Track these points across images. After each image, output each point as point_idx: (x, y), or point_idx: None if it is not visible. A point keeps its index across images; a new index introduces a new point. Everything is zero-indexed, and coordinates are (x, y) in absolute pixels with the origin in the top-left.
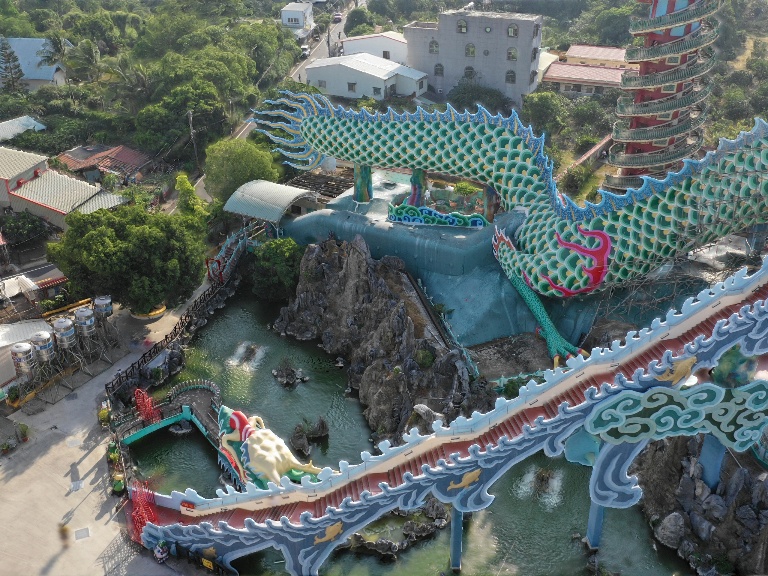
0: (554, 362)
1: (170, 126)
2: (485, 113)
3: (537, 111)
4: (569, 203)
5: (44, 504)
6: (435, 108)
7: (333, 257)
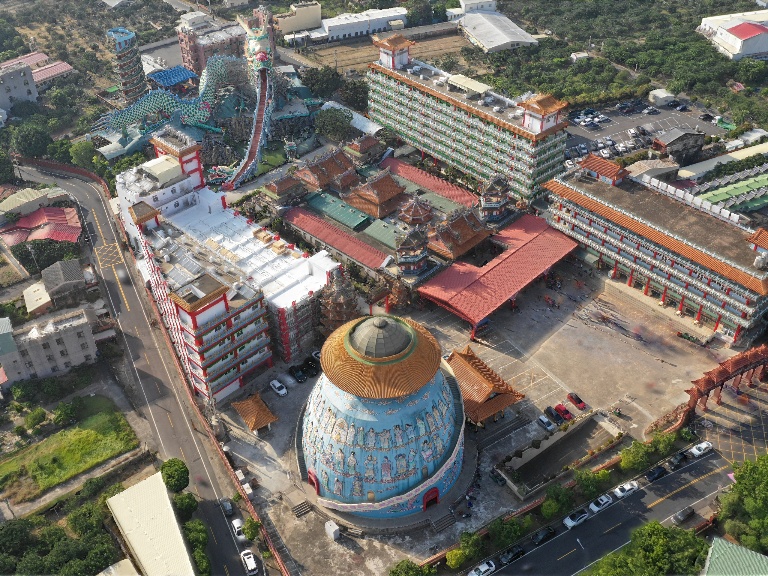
0: None
1: (2, 168)
2: None
3: None
4: None
5: None
6: (37, 116)
7: None
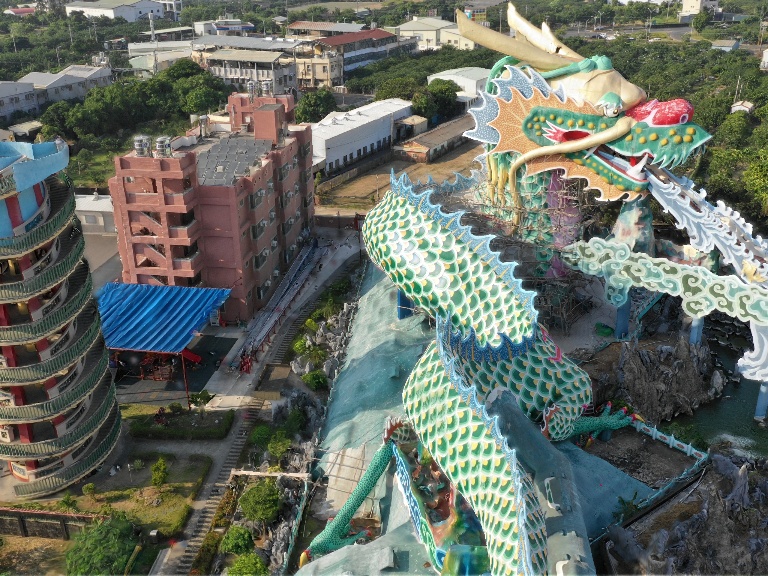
0: (640, 419)
1: None
2: None
3: None
4: None
5: None
6: None
7: None
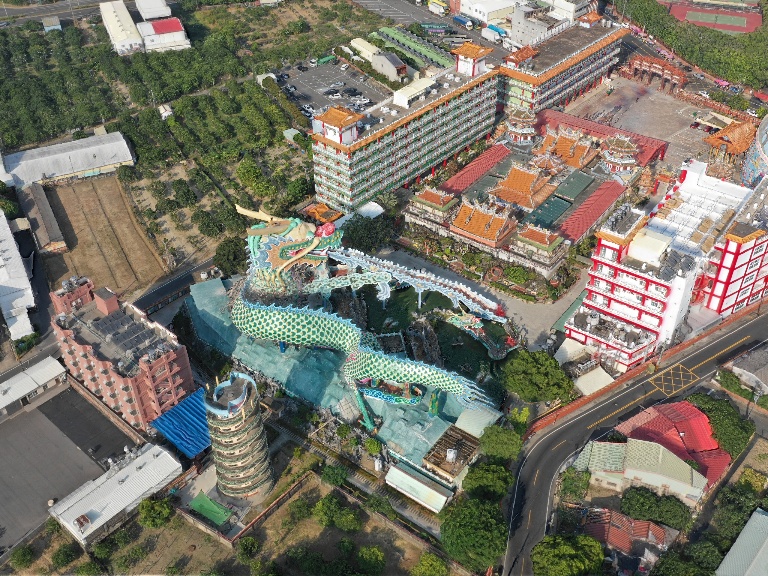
0: None
1: None
2: None
3: None
4: None
5: (530, 322)
6: None
7: None
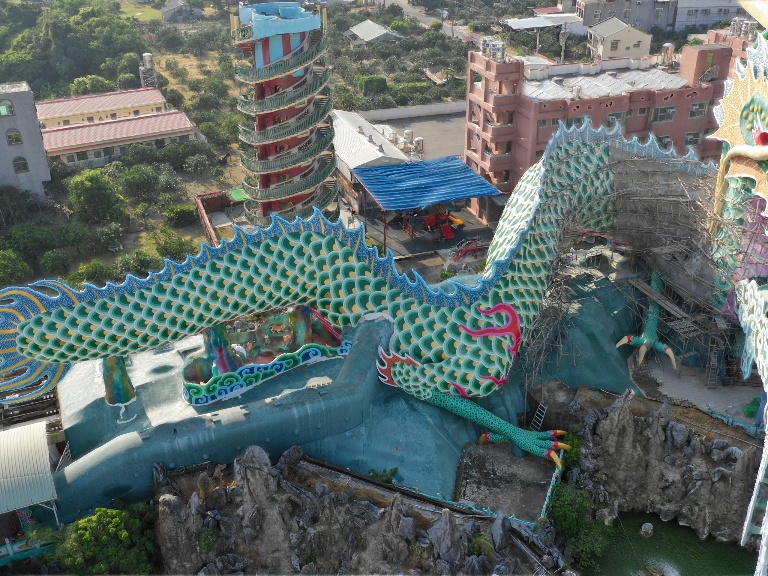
0: (554, 459)
1: None
2: (281, 222)
3: (94, 196)
4: (460, 288)
5: None
6: None
7: (216, 496)
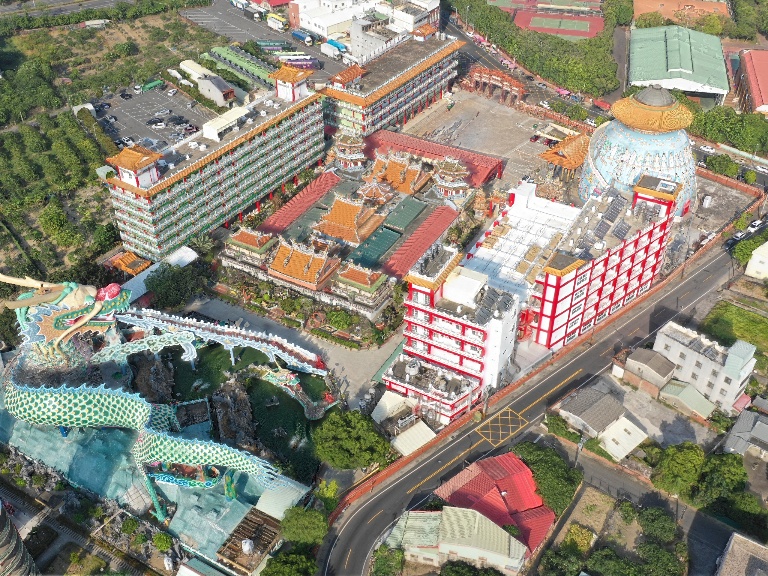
0: None
1: None
2: None
3: None
4: None
5: (352, 372)
6: None
7: None
